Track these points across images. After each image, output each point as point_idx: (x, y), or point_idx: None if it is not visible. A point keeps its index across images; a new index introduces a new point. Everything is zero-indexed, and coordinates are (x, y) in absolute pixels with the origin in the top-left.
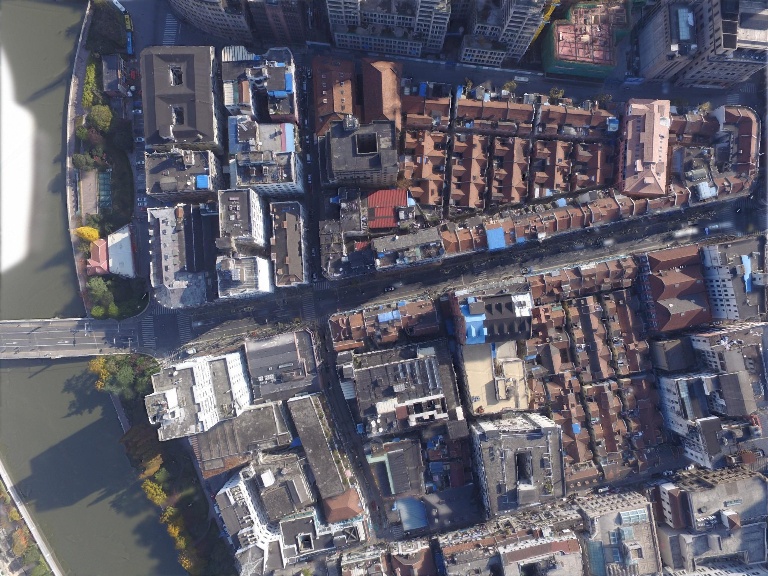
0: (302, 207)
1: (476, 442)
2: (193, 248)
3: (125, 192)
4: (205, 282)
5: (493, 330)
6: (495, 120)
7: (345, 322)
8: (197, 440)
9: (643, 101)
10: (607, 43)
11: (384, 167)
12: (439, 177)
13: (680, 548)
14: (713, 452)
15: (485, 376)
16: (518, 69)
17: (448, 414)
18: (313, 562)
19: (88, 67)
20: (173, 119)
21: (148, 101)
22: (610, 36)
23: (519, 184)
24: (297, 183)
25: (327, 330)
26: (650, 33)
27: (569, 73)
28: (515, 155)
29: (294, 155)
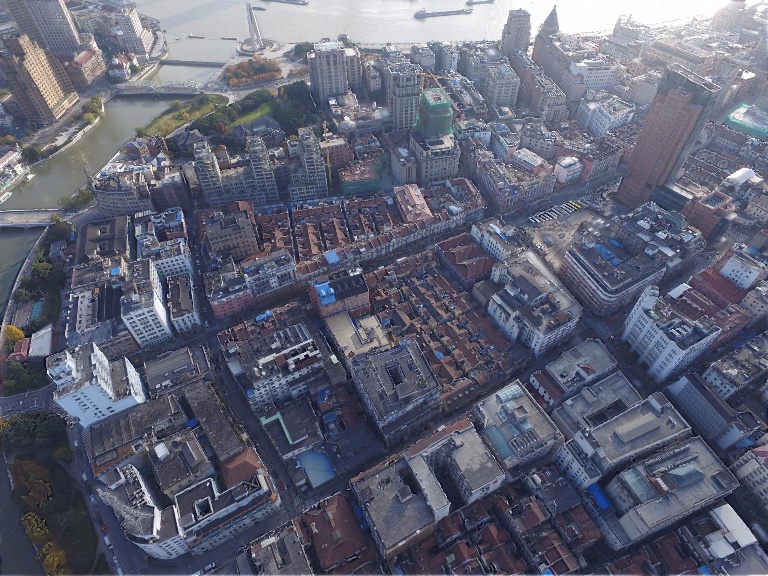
0: None
1: (355, 377)
2: (104, 306)
3: (53, 310)
4: (112, 324)
5: (337, 288)
6: (318, 215)
7: (230, 331)
8: (91, 441)
9: None
10: (370, 171)
11: (242, 228)
12: (289, 246)
13: (571, 418)
14: (537, 325)
15: (348, 332)
16: (329, 199)
17: (326, 365)
18: (221, 569)
19: (39, 251)
20: (98, 250)
21: (81, 244)
22: (371, 169)
23: None
24: (186, 258)
25: (220, 355)
26: (393, 166)
27: (358, 191)
28: (336, 225)
29: (183, 246)
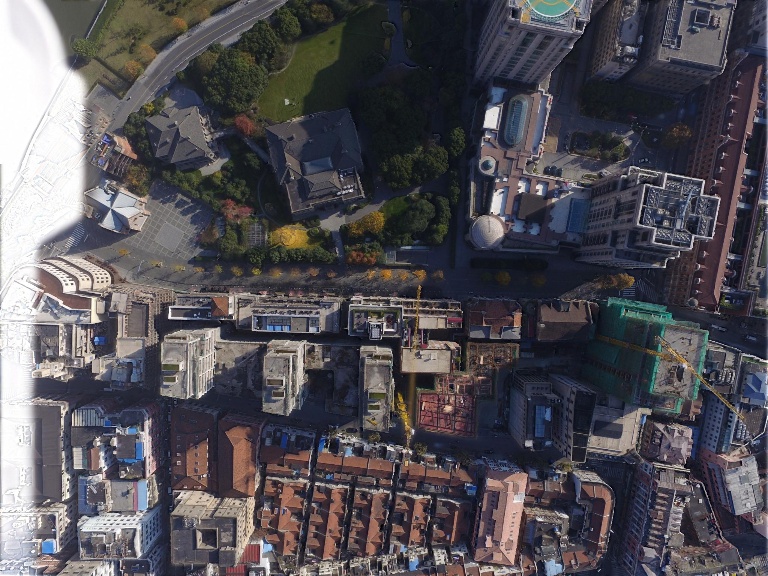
0: (155, 557)
1: None
2: None
3: None
4: None
5: None
6: (355, 474)
7: None
8: None
9: (500, 474)
10: (469, 416)
11: None
12: (296, 527)
13: None
14: None
15: None
16: None
17: None
18: None
19: None
20: (21, 478)
21: None
22: (473, 408)
23: (375, 537)
24: (143, 552)
25: None
26: (516, 401)
27: None
28: (372, 511)
29: (141, 525)
